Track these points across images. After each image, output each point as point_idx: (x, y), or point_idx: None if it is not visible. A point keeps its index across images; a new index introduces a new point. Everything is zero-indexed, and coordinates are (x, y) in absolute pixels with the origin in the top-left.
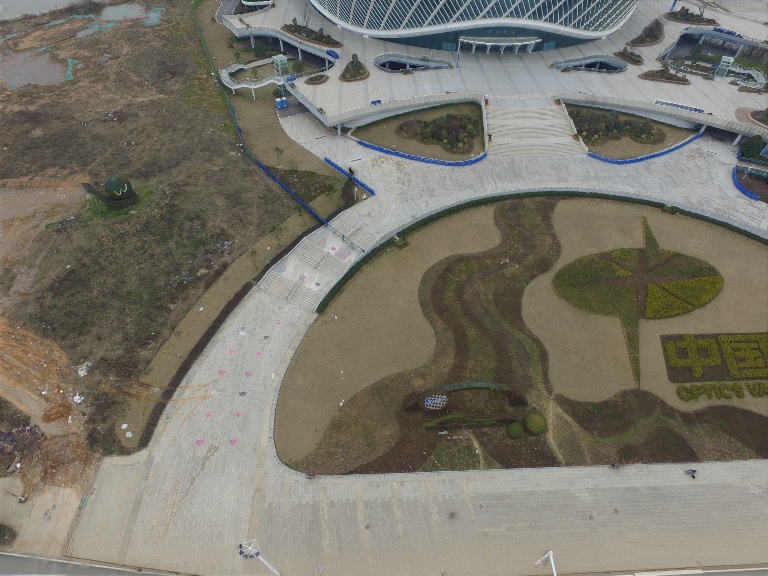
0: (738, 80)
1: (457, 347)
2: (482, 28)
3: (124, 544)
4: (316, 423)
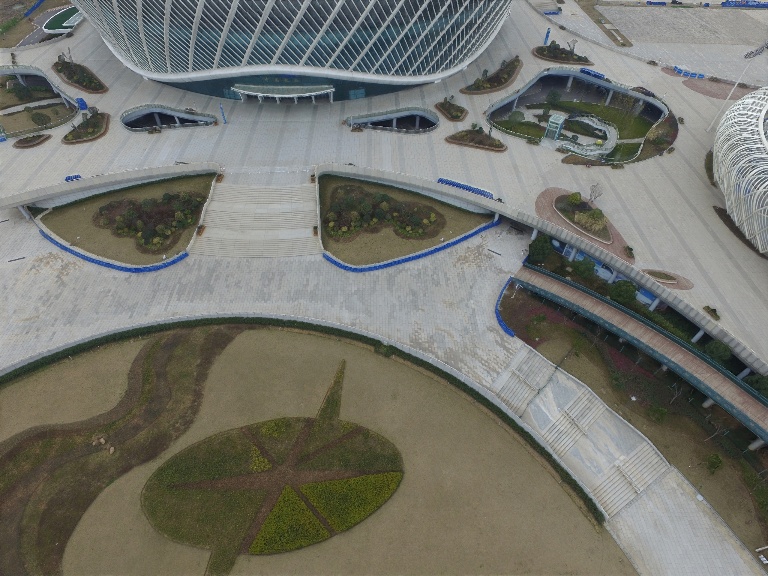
0: (566, 147)
1: None
2: (254, 75)
3: None
4: None
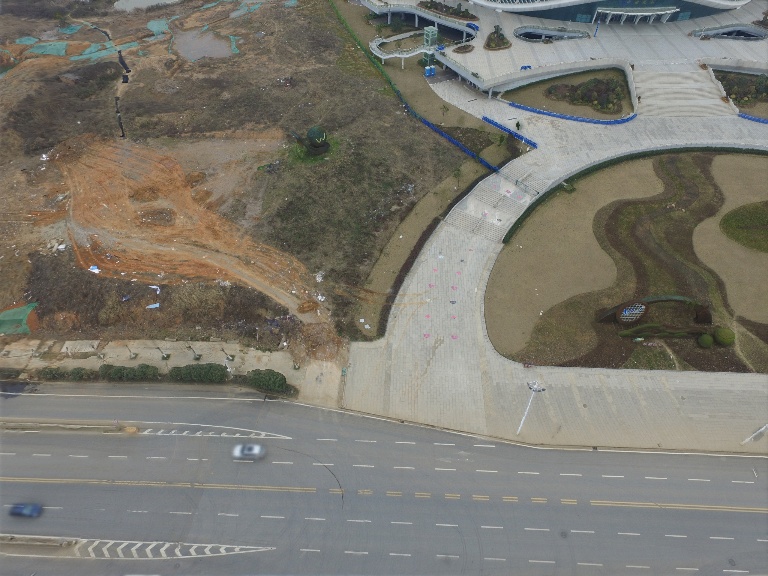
0: None
1: (638, 274)
2: None
3: (385, 403)
4: (522, 327)
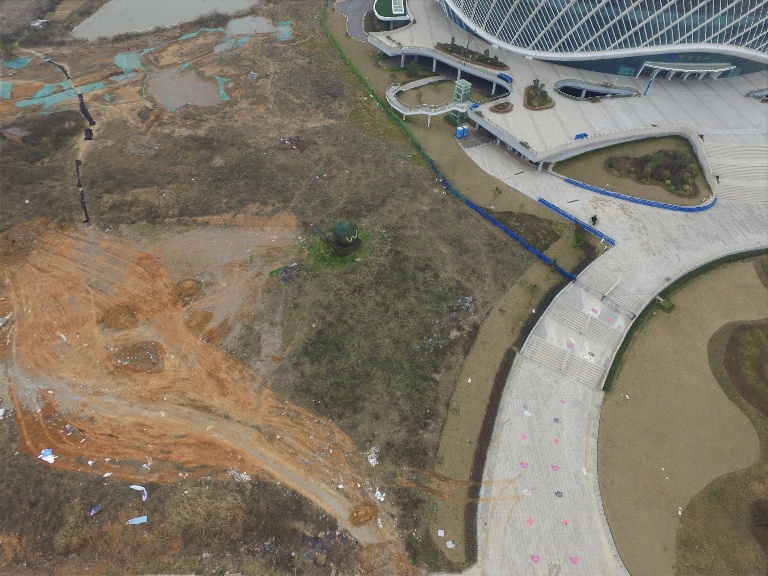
0: None
1: None
2: (675, 53)
3: None
4: (661, 538)
